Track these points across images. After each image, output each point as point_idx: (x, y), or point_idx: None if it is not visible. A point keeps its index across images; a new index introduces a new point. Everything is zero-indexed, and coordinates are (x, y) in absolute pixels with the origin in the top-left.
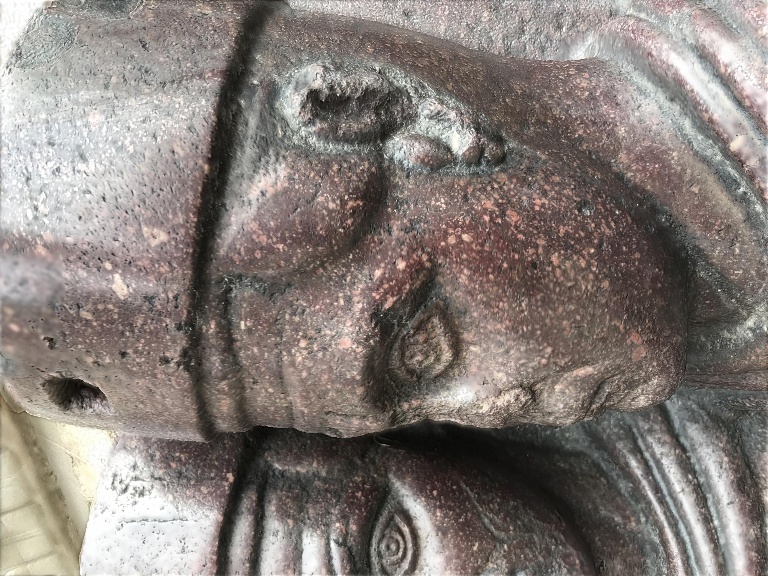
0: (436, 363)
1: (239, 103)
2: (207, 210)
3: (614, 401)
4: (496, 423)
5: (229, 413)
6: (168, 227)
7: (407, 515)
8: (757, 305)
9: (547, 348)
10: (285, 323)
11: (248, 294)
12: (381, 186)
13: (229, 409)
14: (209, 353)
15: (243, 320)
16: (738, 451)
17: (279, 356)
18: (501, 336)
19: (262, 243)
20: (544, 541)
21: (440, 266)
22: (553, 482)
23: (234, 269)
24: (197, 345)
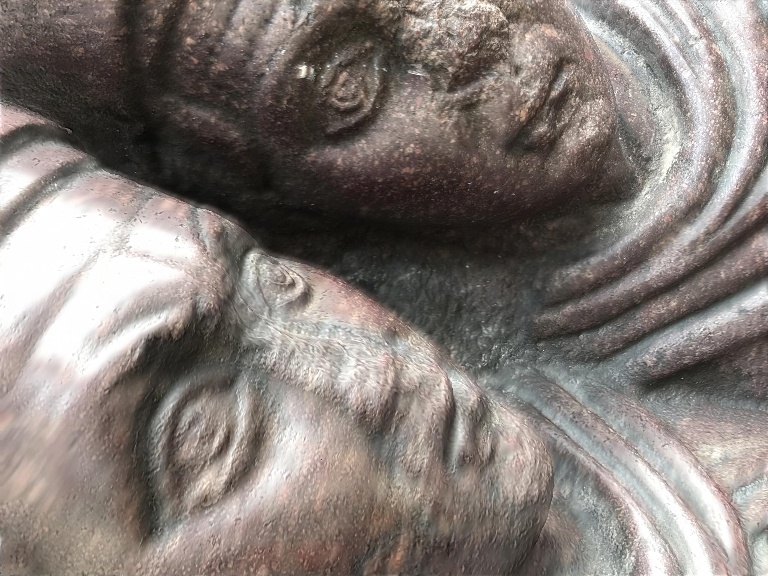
0: None
1: None
2: None
3: (565, 120)
4: (472, 40)
5: None
6: None
7: None
8: (650, 164)
9: None
10: None
11: None
12: None
13: None
14: None
15: None
16: None
17: None
18: None
19: None
20: None
21: None
22: None
23: None
24: None
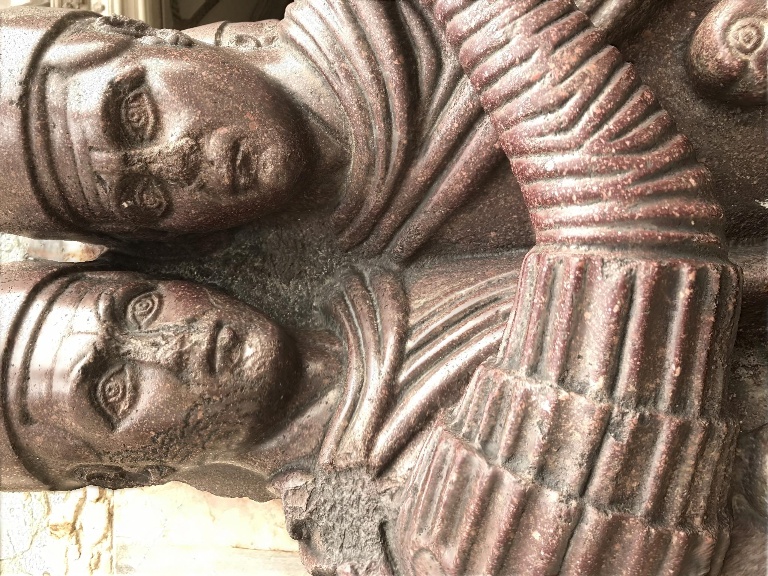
0: (147, 125)
1: (75, 21)
2: (45, 41)
3: (255, 168)
4: (180, 164)
5: (41, 151)
6: (26, 44)
7: (161, 296)
8: (349, 141)
9: (198, 111)
10: (70, 89)
11: (56, 76)
12: (127, 45)
13: (41, 146)
14: (33, 103)
15: (51, 87)
16: (399, 284)
17: (66, 106)
18: (175, 105)
19: (65, 53)
20: (250, 316)
21: (147, 72)
22: (289, 330)
23: (51, 63)
24: (28, 97)
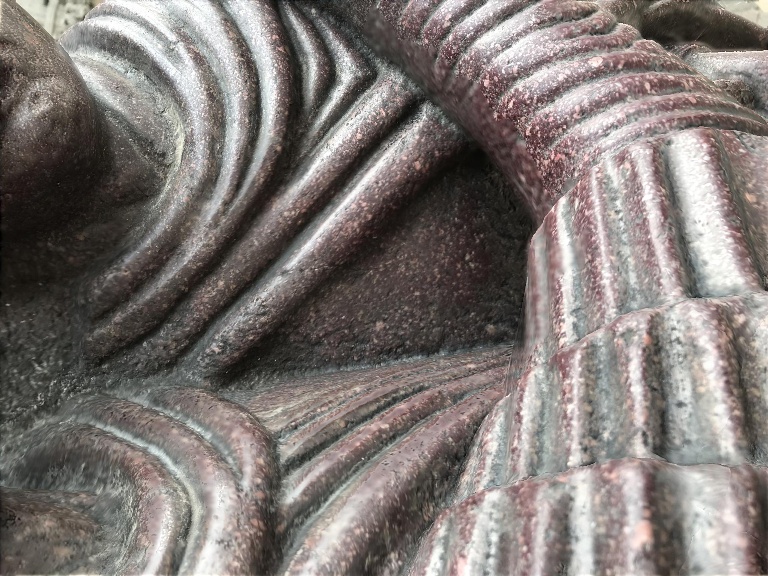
0: None
1: None
2: None
3: (10, 95)
4: None
5: None
6: None
7: None
8: (167, 159)
9: None
10: None
11: None
12: None
13: None
14: None
15: None
16: None
17: None
18: None
19: None
20: None
21: None
22: None
23: None
24: None
